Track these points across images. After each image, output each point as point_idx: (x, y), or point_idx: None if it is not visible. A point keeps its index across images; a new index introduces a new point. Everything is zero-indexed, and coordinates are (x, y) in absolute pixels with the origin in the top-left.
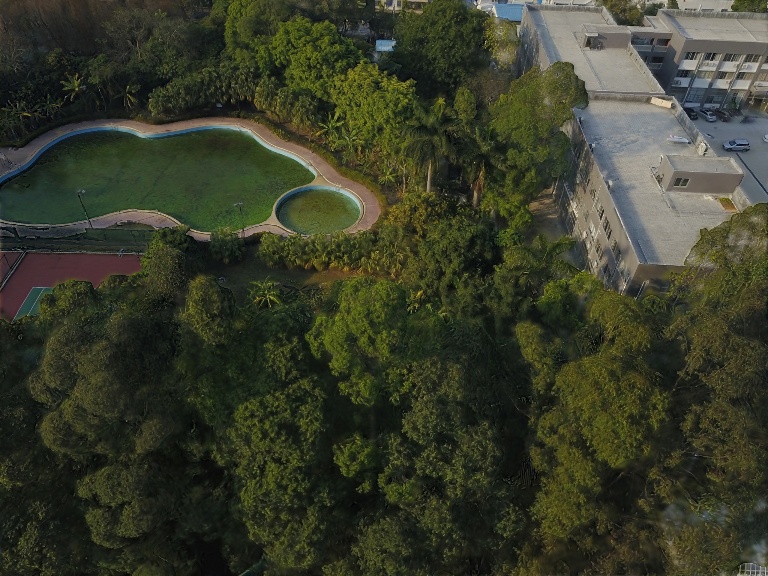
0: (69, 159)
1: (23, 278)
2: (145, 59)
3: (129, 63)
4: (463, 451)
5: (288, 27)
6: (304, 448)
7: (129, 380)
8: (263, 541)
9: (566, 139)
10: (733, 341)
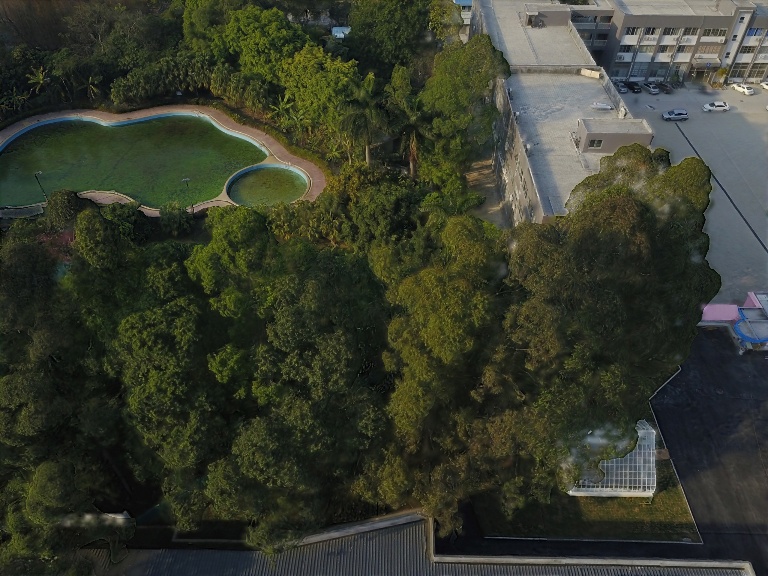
0: (35, 147)
1: None
2: (107, 51)
3: (92, 56)
4: (321, 356)
5: (238, 15)
6: (179, 355)
7: (19, 295)
8: (156, 445)
9: (493, 109)
10: (542, 247)
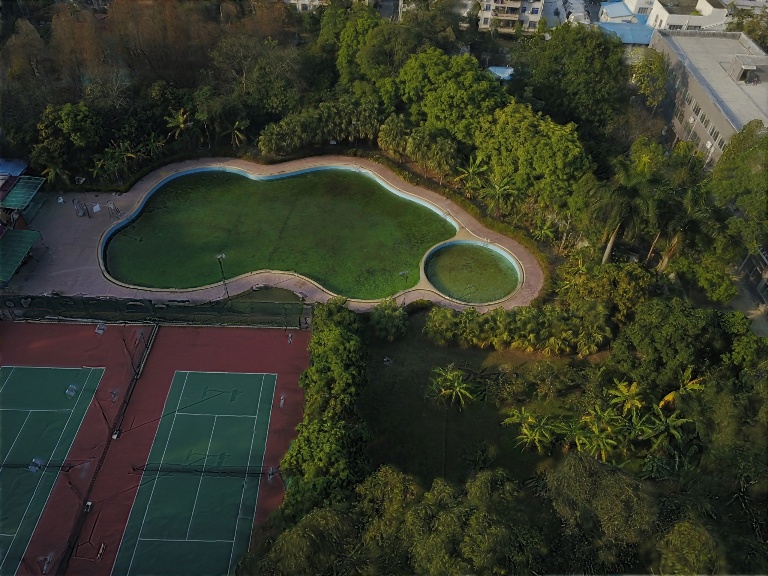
0: (179, 206)
1: (162, 359)
2: (252, 91)
3: (233, 95)
4: None
5: (423, 60)
6: None
7: None
8: None
9: None
10: None
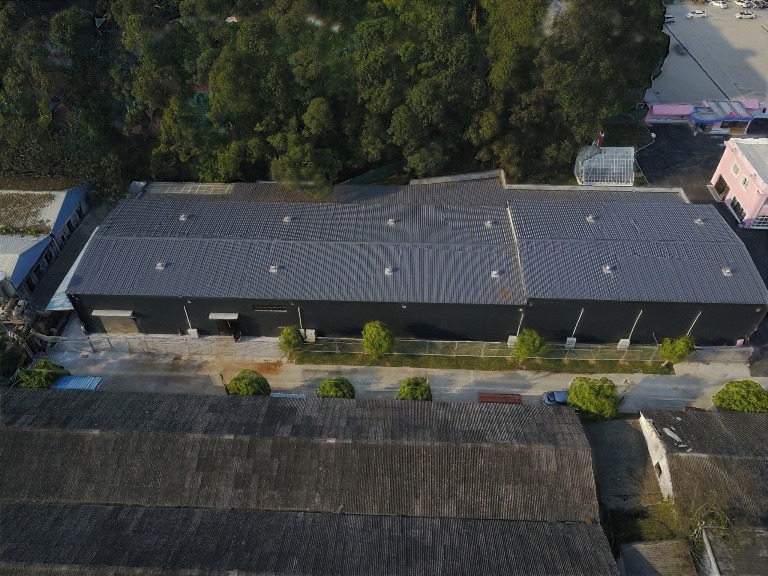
0: None
1: None
2: None
3: None
4: (456, 47)
5: None
6: (385, 42)
7: None
8: (365, 101)
9: None
10: None
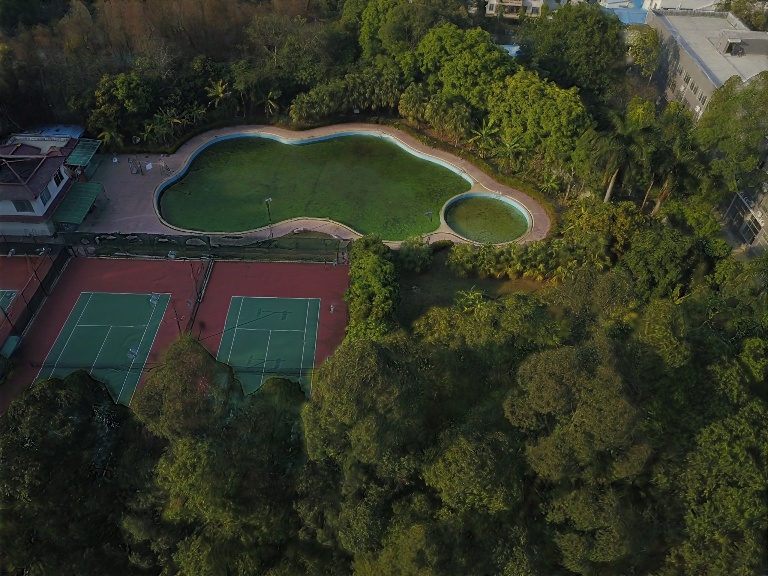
0: (221, 166)
1: (219, 287)
2: (283, 65)
3: (265, 69)
4: None
5: (440, 34)
6: (765, 472)
7: None
8: (686, 563)
9: (755, 148)
10: None
